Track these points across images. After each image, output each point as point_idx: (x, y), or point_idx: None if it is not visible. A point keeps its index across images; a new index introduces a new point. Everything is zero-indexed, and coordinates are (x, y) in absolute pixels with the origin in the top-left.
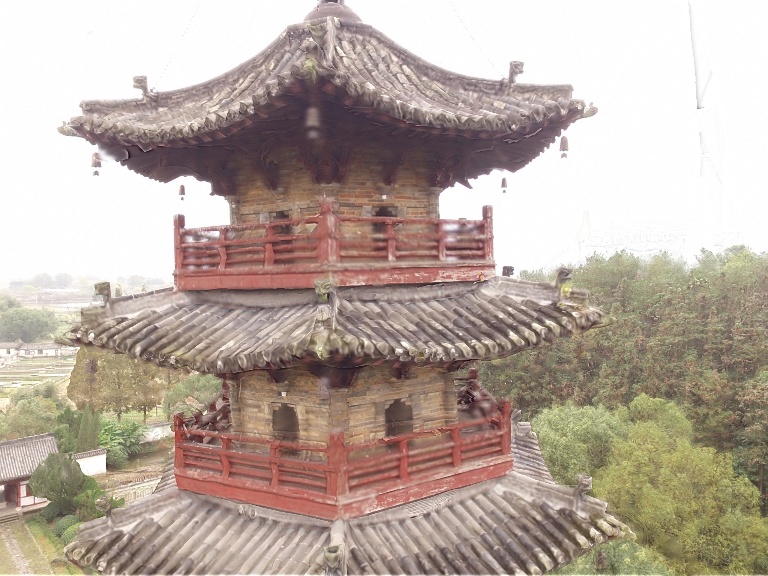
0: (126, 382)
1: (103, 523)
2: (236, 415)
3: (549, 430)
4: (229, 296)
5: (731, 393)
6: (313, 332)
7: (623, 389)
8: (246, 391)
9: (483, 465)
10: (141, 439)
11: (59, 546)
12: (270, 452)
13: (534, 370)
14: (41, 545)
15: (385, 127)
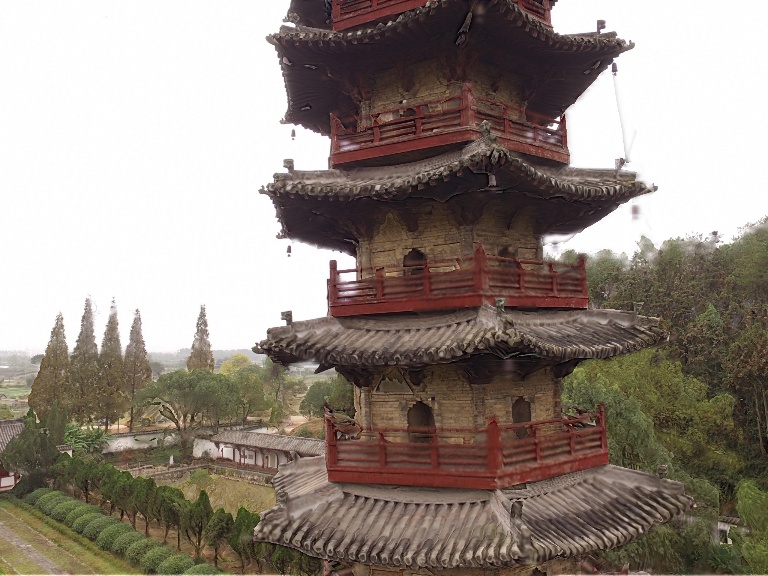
0: (90, 392)
1: None
2: None
3: None
4: None
5: None
6: None
7: None
8: None
9: (535, 19)
10: (105, 446)
11: (34, 510)
12: None
13: None
14: (13, 512)
15: None
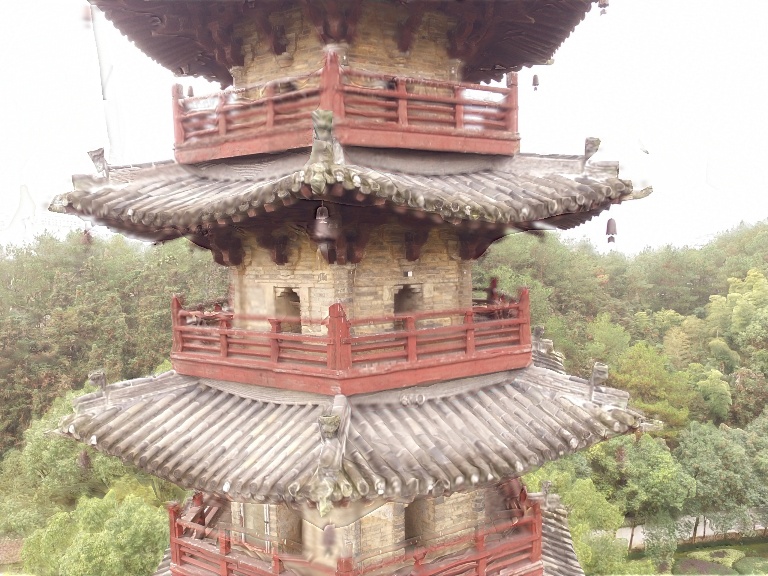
0: None
1: (336, 447)
2: (351, 307)
3: None
4: (384, 160)
5: None
6: None
7: (118, 367)
8: (361, 277)
9: None
10: None
11: None
12: (468, 319)
13: (1, 364)
14: None
15: (525, 24)
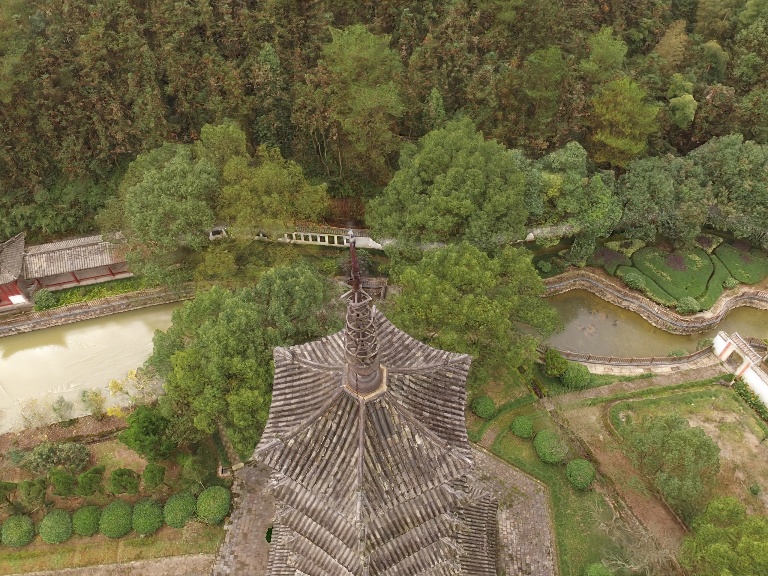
0: None
1: None
2: None
3: (171, 201)
4: None
5: (247, 80)
6: (465, 500)
7: (156, 93)
8: None
9: None
10: None
11: None
12: None
13: (55, 94)
14: None
15: None
